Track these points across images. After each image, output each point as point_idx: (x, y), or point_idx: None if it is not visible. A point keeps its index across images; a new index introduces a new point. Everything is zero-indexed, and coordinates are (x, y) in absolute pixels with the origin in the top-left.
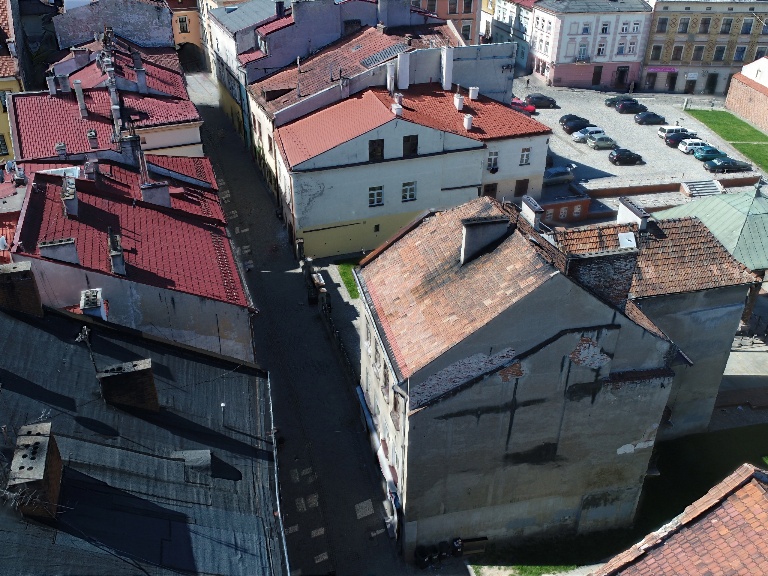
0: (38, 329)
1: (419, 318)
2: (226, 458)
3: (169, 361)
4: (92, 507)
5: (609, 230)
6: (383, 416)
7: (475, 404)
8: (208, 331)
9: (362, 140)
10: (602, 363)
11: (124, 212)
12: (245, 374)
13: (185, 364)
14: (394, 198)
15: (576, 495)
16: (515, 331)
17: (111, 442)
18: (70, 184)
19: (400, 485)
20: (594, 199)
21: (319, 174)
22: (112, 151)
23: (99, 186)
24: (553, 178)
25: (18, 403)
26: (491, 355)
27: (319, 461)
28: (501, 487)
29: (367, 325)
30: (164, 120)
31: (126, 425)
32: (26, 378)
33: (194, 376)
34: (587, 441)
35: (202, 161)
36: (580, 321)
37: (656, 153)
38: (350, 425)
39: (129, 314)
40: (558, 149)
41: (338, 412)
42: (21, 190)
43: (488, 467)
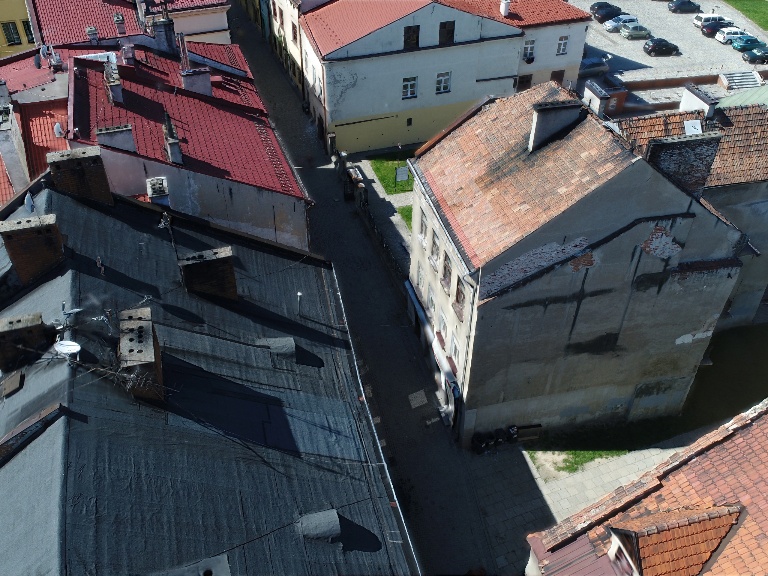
0: (110, 217)
1: (486, 208)
2: (306, 346)
3: (238, 251)
4: (194, 390)
5: (675, 117)
6: (440, 308)
7: (543, 294)
8: (264, 223)
9: (397, 26)
10: (672, 253)
11: (167, 100)
12: (311, 265)
13: (253, 254)
14: (428, 90)
15: (630, 384)
16: (590, 220)
17: (199, 329)
18: (113, 69)
19: (462, 375)
20: (629, 92)
21: (352, 63)
22: (145, 36)
23: (138, 73)
24: (588, 69)
25: (106, 290)
26: (564, 244)
27: (369, 354)
28: (560, 376)
29: (422, 218)
30: (190, 4)
31: (210, 313)
32: (109, 266)
33: (264, 266)
34: (648, 331)
35: (232, 49)
36: (656, 209)
37: (692, 43)
38: (397, 319)
39: (187, 205)
40: (590, 39)
41: (384, 307)
42: (59, 76)
43: (550, 357)
